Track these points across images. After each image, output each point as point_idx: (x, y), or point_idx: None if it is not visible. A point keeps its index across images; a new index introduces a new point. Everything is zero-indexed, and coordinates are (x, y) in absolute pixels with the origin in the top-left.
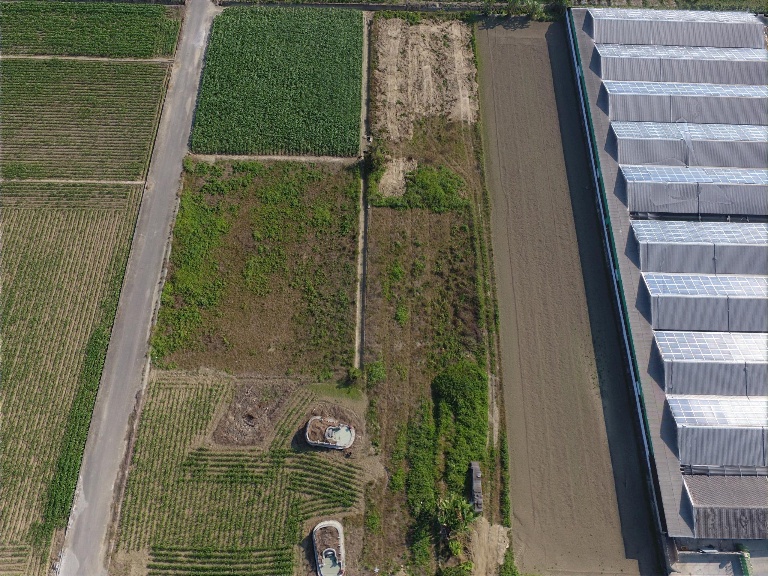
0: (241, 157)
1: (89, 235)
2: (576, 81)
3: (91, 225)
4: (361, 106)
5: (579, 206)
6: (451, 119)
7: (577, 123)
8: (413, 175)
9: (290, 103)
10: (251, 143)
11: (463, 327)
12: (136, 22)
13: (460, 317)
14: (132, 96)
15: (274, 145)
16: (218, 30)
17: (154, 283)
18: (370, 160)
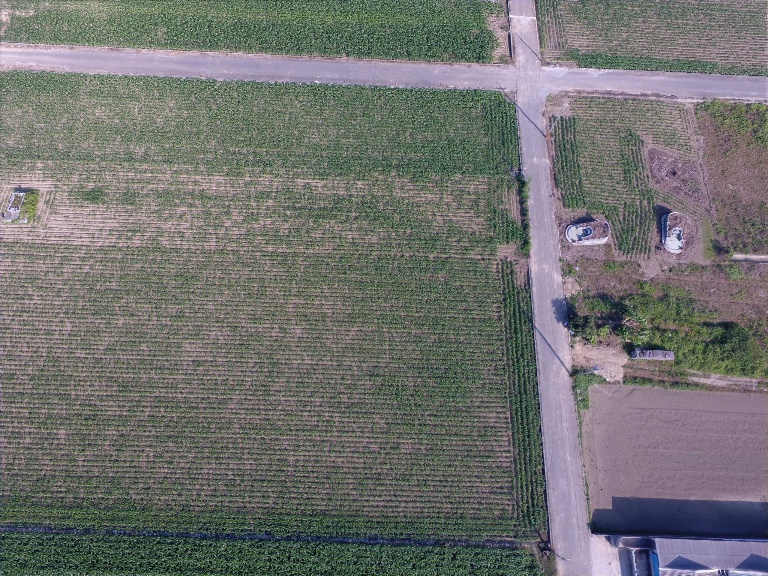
0: None
1: None
2: None
3: None
4: None
5: None
6: None
7: None
8: None
9: None
10: None
11: None
12: None
13: None
14: None
15: None
16: None
17: (764, 97)
18: None
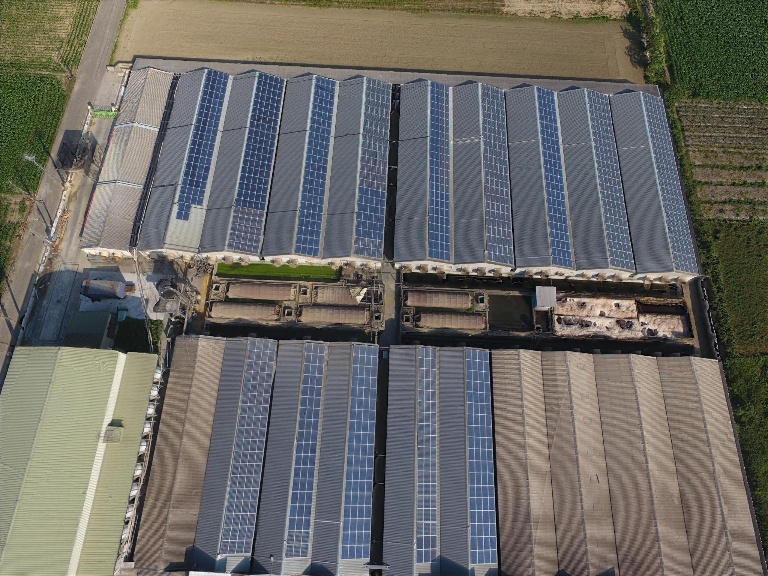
0: None
1: None
2: None
3: None
4: None
5: None
6: None
7: None
8: None
9: None
10: None
11: None
12: None
13: None
14: None
15: None
16: None
17: None
18: None
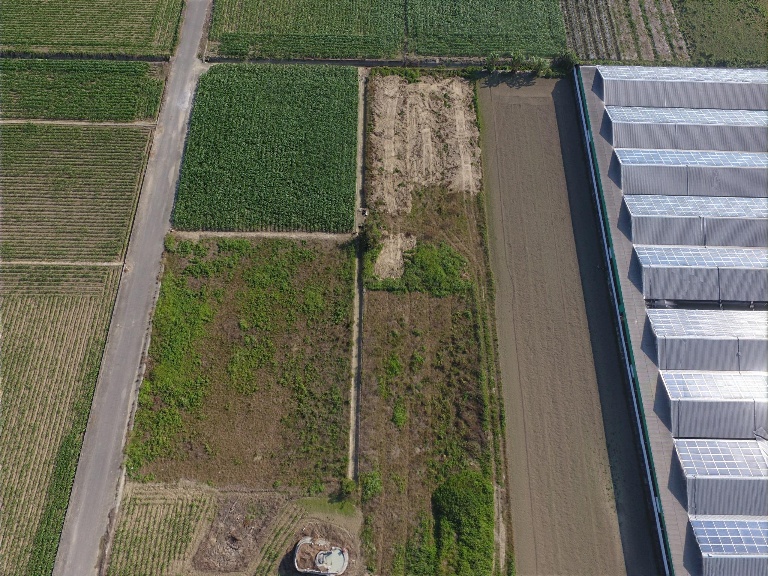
0: (227, 234)
1: (62, 325)
2: (585, 146)
3: (64, 313)
4: (356, 175)
5: (590, 288)
6: (452, 189)
7: (587, 193)
8: (412, 253)
9: (280, 173)
10: (238, 218)
11: (466, 430)
12: (117, 82)
13: (463, 418)
14: (111, 165)
15: (263, 220)
16: (204, 90)
17: (131, 381)
18: (365, 238)
